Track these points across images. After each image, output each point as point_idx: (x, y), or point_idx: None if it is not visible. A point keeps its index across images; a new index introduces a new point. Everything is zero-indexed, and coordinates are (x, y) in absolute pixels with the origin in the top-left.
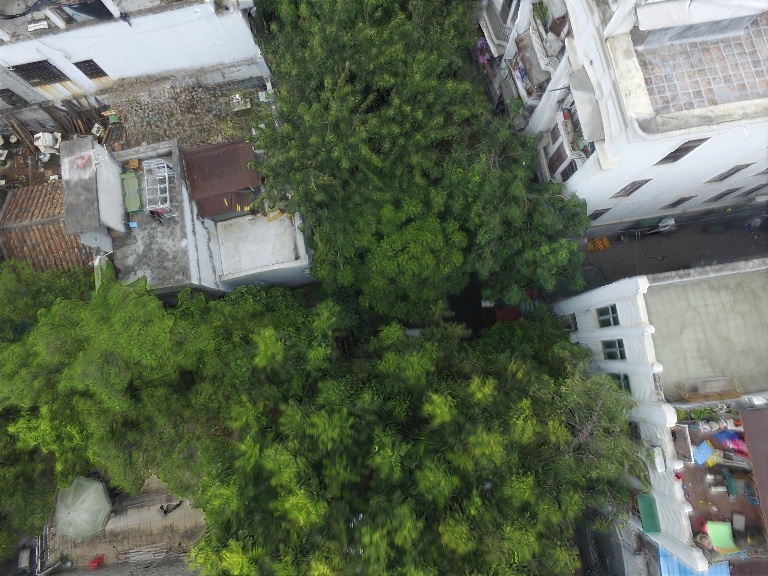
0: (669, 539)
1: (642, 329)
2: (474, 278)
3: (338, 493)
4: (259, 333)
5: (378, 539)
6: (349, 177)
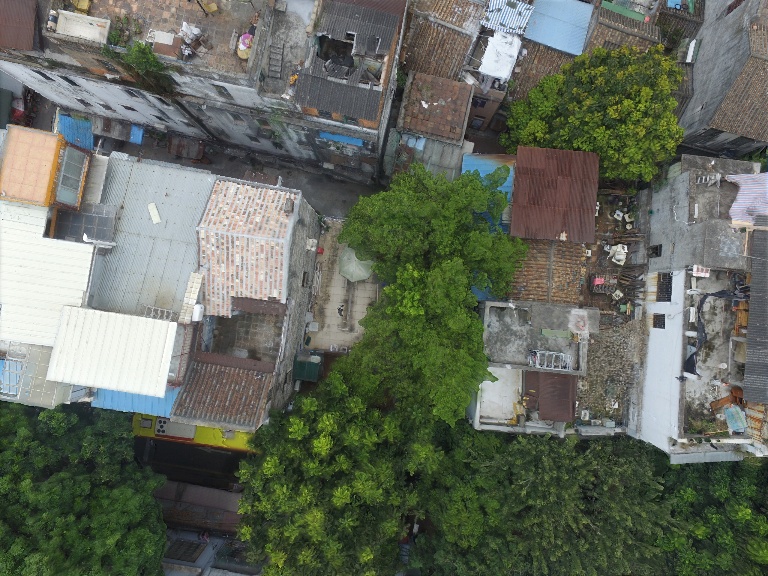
0: None
1: None
2: (435, 528)
3: None
4: None
5: (315, 523)
6: None
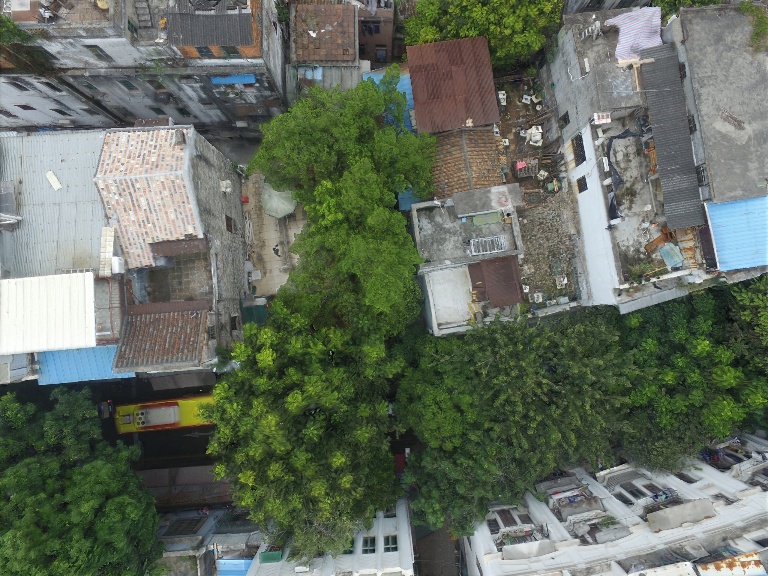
0: (256, 568)
1: (379, 568)
2: (424, 446)
3: (294, 411)
4: (384, 320)
5: (272, 433)
6: (491, 377)
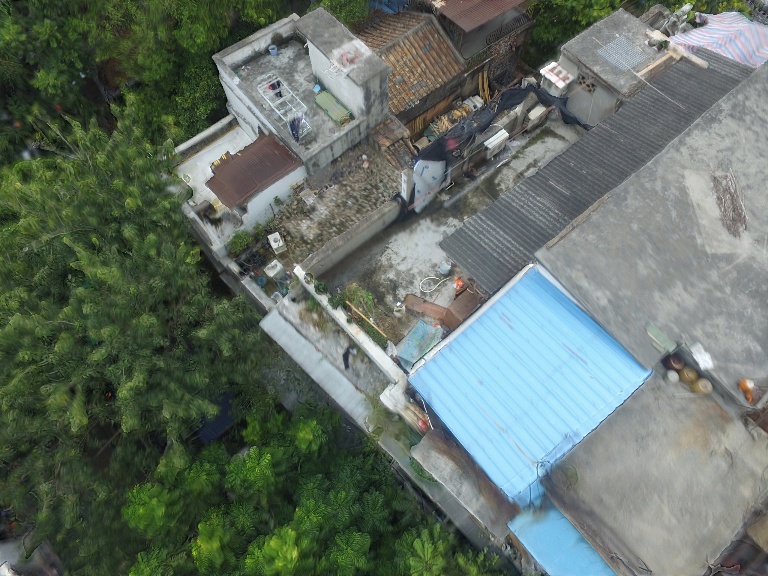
0: None
1: None
2: None
3: None
4: (105, 34)
5: None
6: None
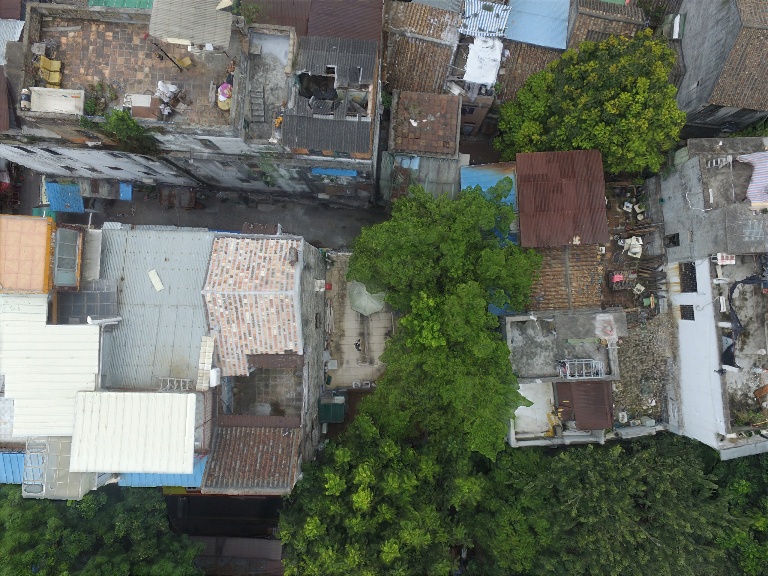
0: None
1: None
2: (484, 551)
3: None
4: (469, 439)
5: None
6: None
